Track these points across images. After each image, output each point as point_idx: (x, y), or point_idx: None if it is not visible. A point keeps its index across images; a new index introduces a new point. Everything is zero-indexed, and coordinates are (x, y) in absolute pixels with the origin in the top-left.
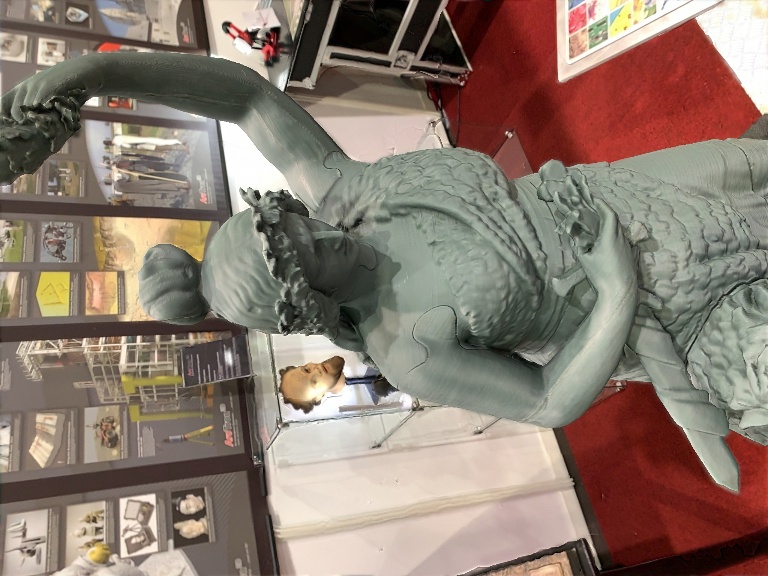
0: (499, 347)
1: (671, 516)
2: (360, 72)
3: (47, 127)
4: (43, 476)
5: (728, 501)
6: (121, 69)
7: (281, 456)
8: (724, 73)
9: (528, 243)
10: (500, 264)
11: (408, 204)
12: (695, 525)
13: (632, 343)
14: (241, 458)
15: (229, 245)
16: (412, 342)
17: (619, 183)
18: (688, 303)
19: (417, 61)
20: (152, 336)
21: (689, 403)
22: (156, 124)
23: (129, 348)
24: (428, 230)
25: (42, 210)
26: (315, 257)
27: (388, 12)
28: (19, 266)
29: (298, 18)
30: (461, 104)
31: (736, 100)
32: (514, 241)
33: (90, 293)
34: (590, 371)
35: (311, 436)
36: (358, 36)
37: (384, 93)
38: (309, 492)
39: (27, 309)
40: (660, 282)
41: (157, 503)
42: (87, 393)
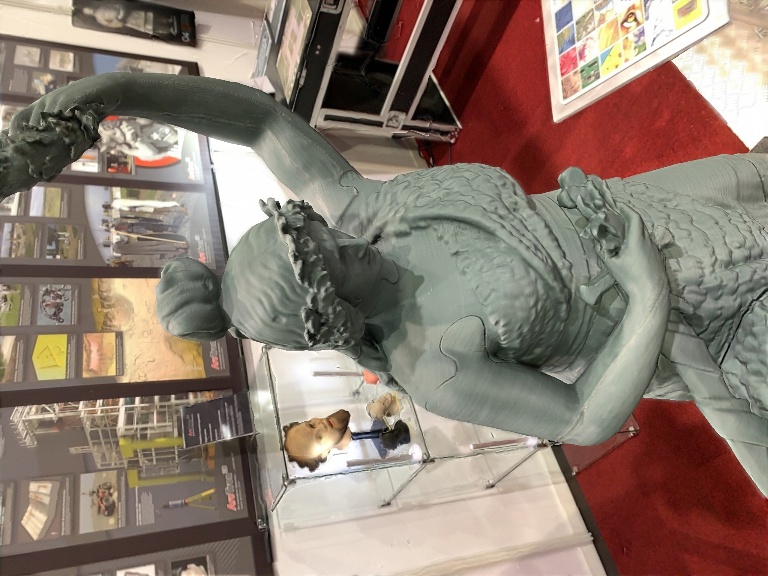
0: (528, 362)
1: (699, 567)
2: (353, 134)
3: (68, 132)
4: (36, 549)
5: (758, 547)
6: (139, 87)
7: (286, 519)
8: (709, 115)
9: (552, 252)
10: (527, 271)
11: (428, 216)
12: (725, 575)
13: (666, 350)
14: (245, 522)
15: (252, 252)
16: (440, 356)
17: (635, 195)
18: (718, 309)
19: (408, 121)
20: (151, 397)
21: (731, 412)
22: (154, 187)
23: (127, 410)
24: (450, 241)
25: (40, 273)
26: (340, 263)
27: (379, 75)
28: (15, 330)
29: (293, 83)
30: (452, 160)
31: (724, 140)
32: (538, 249)
33: (87, 355)
34: (627, 380)
35: (317, 497)
36: (350, 99)
37: (377, 153)
38: (317, 557)
39: (23, 373)
40: (688, 288)
41: (156, 574)
42: (83, 458)
